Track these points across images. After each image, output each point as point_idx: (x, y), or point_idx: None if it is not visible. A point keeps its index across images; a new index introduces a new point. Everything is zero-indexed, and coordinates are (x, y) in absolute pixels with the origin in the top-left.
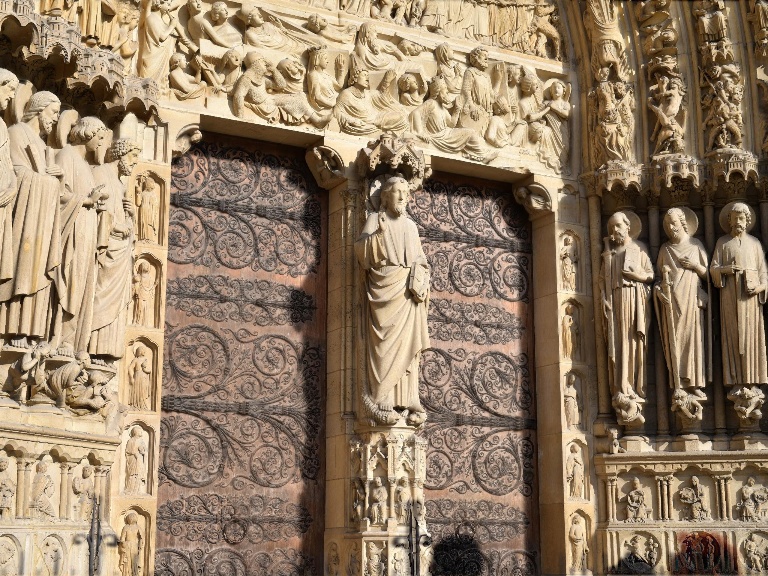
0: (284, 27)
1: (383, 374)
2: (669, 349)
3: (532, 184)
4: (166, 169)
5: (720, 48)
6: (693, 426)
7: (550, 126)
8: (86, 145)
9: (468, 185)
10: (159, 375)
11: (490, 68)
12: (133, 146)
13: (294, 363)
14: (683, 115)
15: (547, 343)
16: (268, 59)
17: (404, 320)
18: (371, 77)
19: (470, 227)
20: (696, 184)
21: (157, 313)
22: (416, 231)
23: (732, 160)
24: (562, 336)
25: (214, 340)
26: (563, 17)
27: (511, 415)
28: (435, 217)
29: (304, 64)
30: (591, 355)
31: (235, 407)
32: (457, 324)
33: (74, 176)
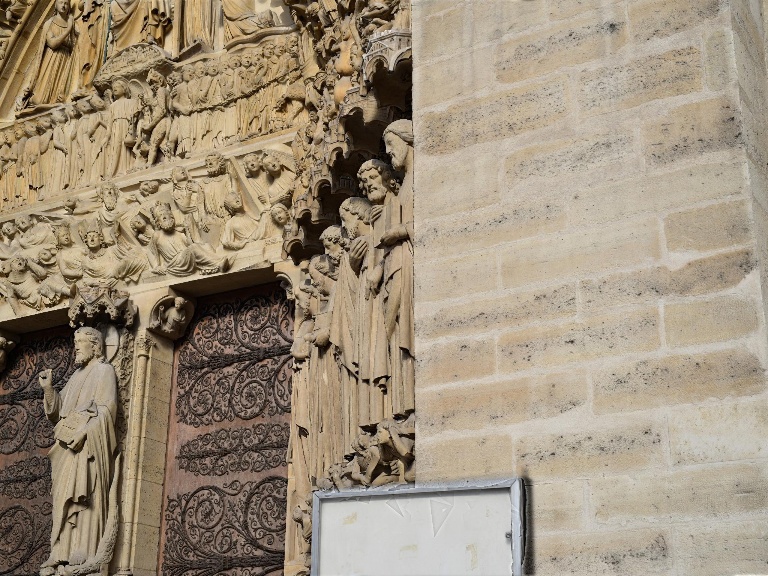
0: (52, 221)
1: None
2: None
3: (277, 275)
4: None
5: None
6: None
7: None
8: None
9: (256, 296)
10: None
11: None
12: None
13: None
14: None
15: None
16: (31, 256)
17: (63, 471)
18: None
19: (255, 341)
20: (311, 220)
21: None
22: (101, 375)
23: None
24: None
25: None
26: None
27: None
28: (219, 343)
29: None
30: None
31: None
32: (234, 454)
33: None
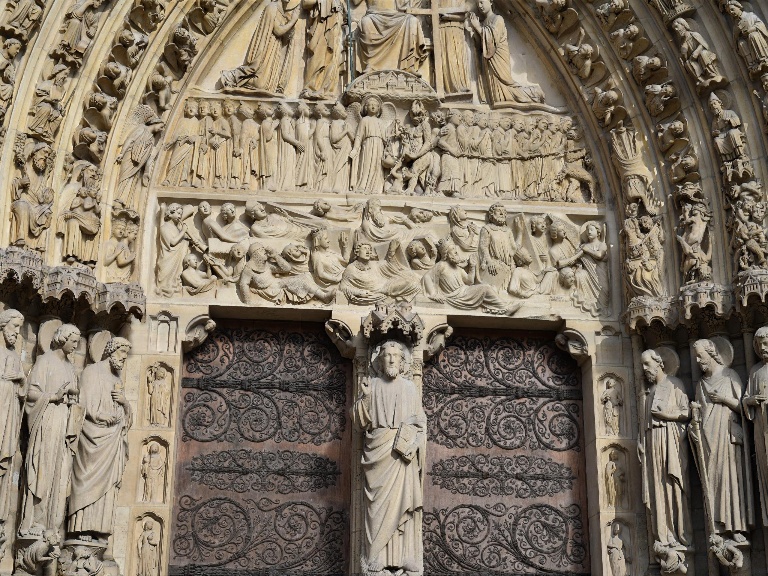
0: (290, 216)
1: (374, 535)
2: (703, 491)
3: (565, 330)
4: (175, 358)
5: (735, 167)
6: (739, 574)
7: (586, 269)
8: (63, 349)
9: (507, 338)
10: (164, 546)
11: (511, 222)
12: (120, 343)
13: (317, 528)
14: (708, 241)
15: (593, 492)
16: (272, 247)
17: (393, 480)
18: (378, 249)
19: (510, 379)
20: (717, 312)
21: (165, 489)
22: (413, 391)
23: (748, 283)
24: (605, 484)
25: (236, 510)
26: (597, 159)
27: (560, 570)
28: (469, 373)
29: (309, 246)
30: (639, 502)
31: (255, 573)
32: (496, 479)
33: (47, 377)
